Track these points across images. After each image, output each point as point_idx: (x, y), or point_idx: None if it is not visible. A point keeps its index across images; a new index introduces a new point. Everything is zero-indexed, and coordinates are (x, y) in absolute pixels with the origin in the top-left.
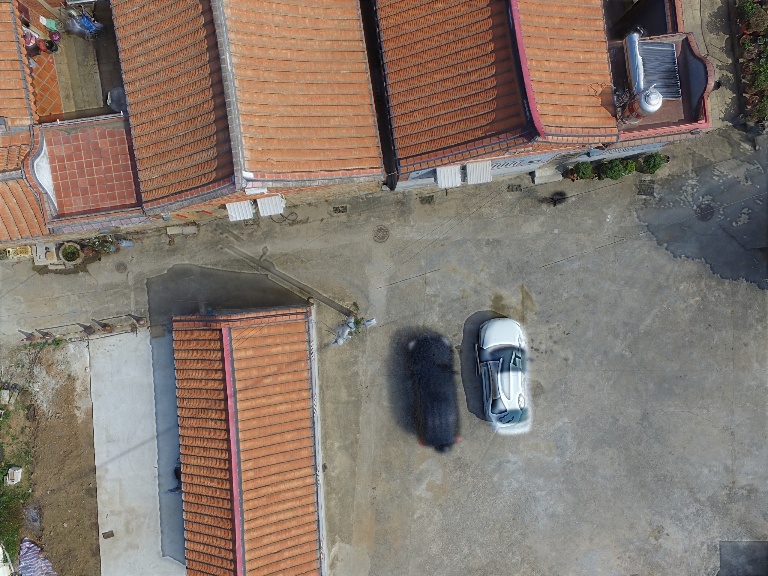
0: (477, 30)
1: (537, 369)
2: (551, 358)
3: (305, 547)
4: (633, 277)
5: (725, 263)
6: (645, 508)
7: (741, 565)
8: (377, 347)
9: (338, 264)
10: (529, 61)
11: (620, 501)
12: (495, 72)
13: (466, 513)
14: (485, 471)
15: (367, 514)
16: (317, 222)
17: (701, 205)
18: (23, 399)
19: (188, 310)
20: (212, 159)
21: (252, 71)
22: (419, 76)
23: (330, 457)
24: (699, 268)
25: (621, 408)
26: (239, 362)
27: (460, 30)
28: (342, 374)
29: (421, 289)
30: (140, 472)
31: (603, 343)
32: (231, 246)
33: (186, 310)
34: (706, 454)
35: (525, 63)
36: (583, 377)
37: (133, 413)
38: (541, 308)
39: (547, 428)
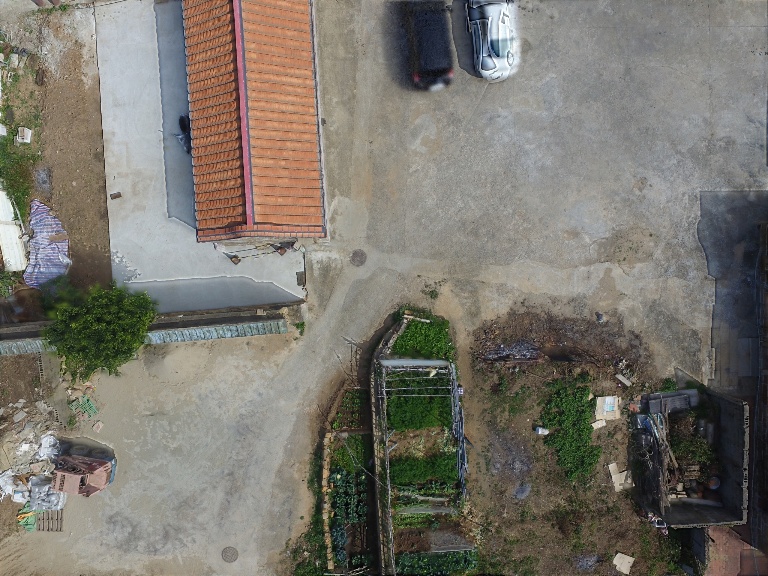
0: None
1: (524, 27)
2: (537, 16)
3: (306, 145)
4: None
5: None
6: (629, 160)
7: (720, 214)
8: (372, 6)
9: None
10: None
11: (605, 154)
12: None
13: (459, 167)
14: (476, 126)
15: (365, 168)
16: None
17: None
18: (32, 63)
19: None
20: None
21: None
22: None
23: (328, 112)
24: None
25: (604, 63)
26: None
27: None
28: (339, 32)
29: None
30: (146, 136)
31: (586, 1)
32: None
33: None
34: (685, 107)
35: None
36: (568, 34)
37: (138, 78)
38: None
39: (535, 83)
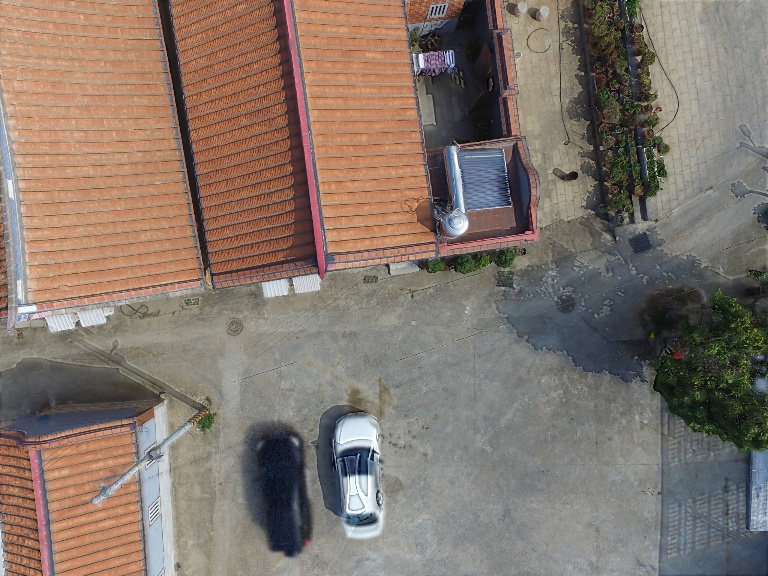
0: (278, 150)
1: (395, 464)
2: (410, 453)
3: None
4: (493, 370)
5: (588, 355)
6: None
7: None
8: (231, 443)
9: (190, 358)
10: (327, 185)
11: None
12: (294, 195)
13: None
14: (343, 569)
15: None
16: (168, 315)
17: (562, 296)
18: None
19: (38, 405)
20: (5, 284)
21: (44, 194)
22: (228, 192)
23: (183, 556)
24: (561, 361)
25: (482, 504)
26: (52, 483)
27: (263, 148)
28: (195, 471)
29: (276, 383)
30: None
31: (463, 438)
32: (81, 340)
33: (36, 405)
34: (570, 551)
35: (313, 193)
36: (442, 473)
37: None
38: (399, 402)
39: (406, 525)
